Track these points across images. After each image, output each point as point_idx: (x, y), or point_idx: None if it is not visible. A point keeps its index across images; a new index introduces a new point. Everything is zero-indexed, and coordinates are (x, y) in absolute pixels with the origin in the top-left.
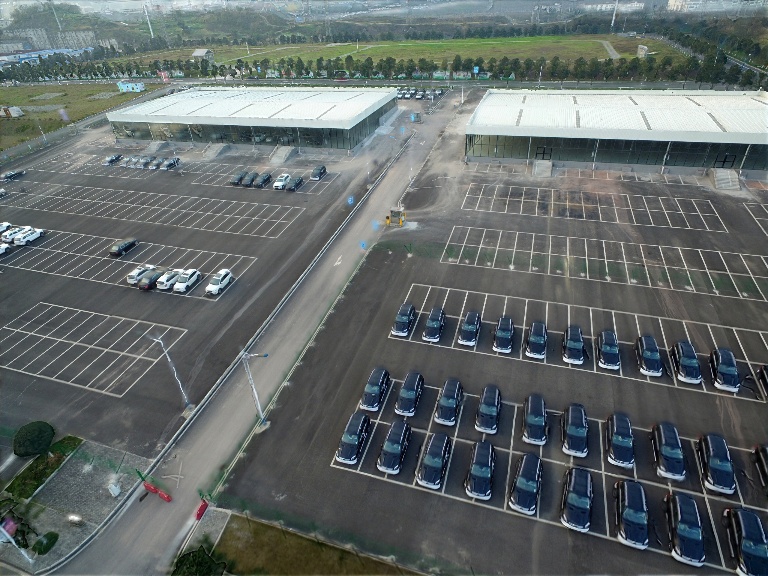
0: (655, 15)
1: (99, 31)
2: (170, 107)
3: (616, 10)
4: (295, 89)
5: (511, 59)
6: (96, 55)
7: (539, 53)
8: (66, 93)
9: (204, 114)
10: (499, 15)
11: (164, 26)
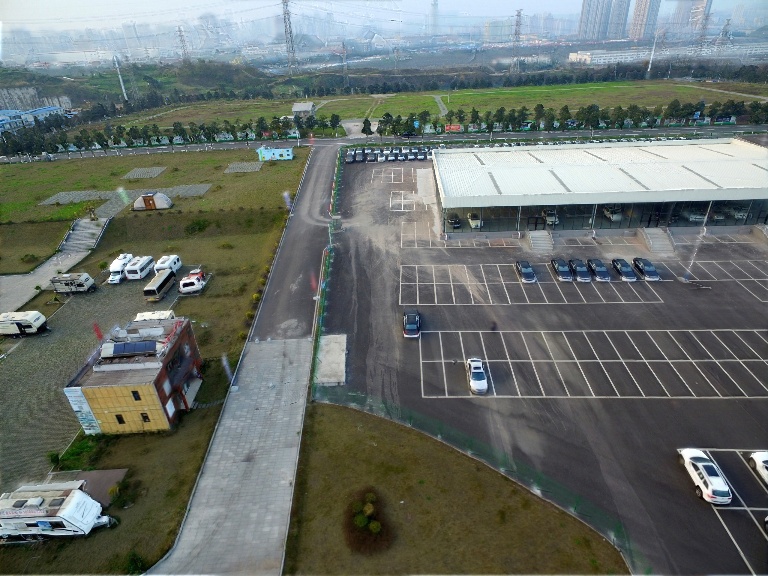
0: (679, 62)
1: (41, 87)
2: (503, 180)
3: (652, 58)
4: (588, 145)
5: (664, 104)
6: (97, 115)
7: (668, 97)
8: (174, 167)
9: (596, 187)
10: (482, 66)
11: (134, 80)
